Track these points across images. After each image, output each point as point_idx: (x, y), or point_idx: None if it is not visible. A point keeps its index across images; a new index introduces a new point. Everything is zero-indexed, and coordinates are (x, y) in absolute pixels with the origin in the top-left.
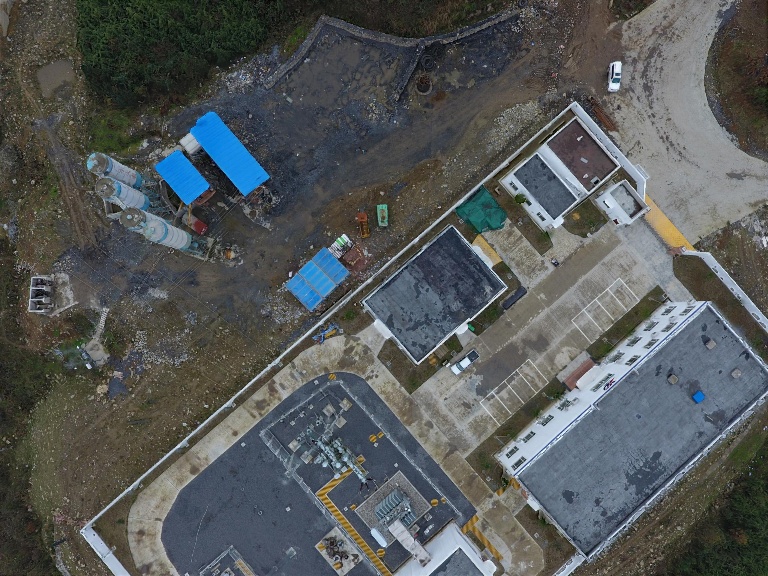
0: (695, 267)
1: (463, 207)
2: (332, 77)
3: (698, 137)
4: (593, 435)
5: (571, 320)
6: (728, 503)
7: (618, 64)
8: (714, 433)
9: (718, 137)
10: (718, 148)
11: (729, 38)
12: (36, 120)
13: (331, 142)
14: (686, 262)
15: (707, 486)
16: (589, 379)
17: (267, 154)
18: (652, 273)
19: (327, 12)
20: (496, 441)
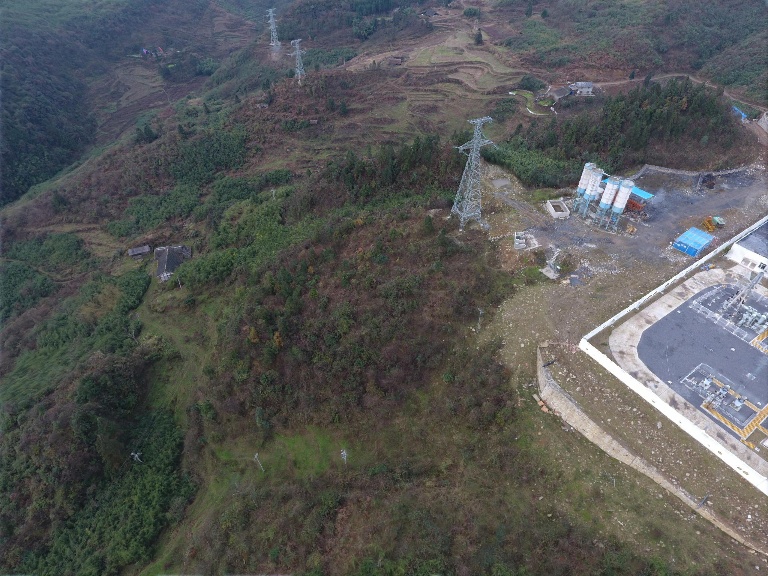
0: None
1: None
2: None
3: None
4: None
5: None
6: None
7: None
8: None
9: None
10: None
11: None
12: (495, 193)
13: (669, 200)
14: None
15: None
16: None
17: None
18: None
19: None
20: None
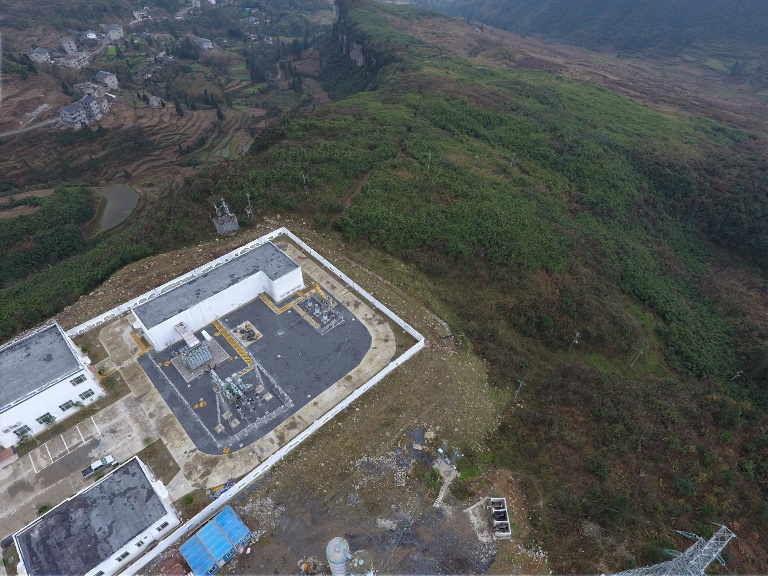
0: None
1: None
2: None
3: None
4: (2, 398)
5: None
6: None
7: None
8: None
9: None
10: None
11: None
12: None
13: None
14: None
15: None
16: None
17: None
18: None
19: None
20: (100, 405)
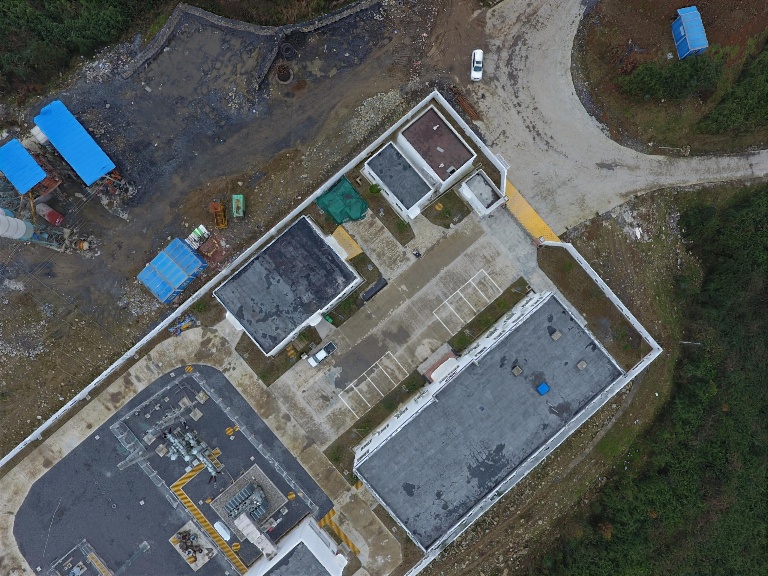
0: (560, 258)
1: (322, 197)
2: (192, 66)
3: (566, 126)
4: (435, 427)
5: (432, 312)
6: (598, 497)
7: (479, 52)
8: (559, 425)
9: (587, 127)
10: (587, 138)
11: (593, 26)
12: None
13: (190, 132)
14: (551, 253)
15: (574, 480)
16: (444, 371)
17: (124, 144)
18: (516, 264)
19: (186, 0)
20: (354, 434)
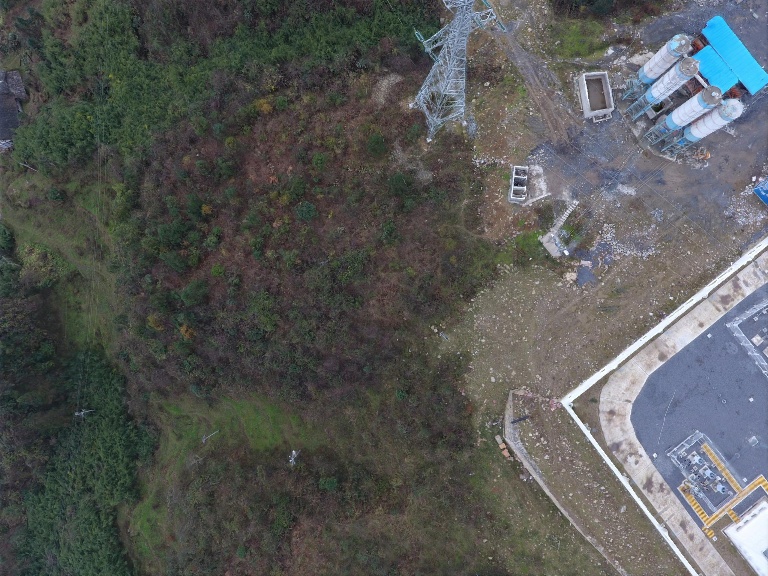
0: None
1: None
2: None
3: None
4: None
5: None
6: None
7: None
8: None
9: None
10: None
11: None
12: (496, 26)
13: None
14: None
15: None
16: None
17: None
18: None
19: None
20: None
